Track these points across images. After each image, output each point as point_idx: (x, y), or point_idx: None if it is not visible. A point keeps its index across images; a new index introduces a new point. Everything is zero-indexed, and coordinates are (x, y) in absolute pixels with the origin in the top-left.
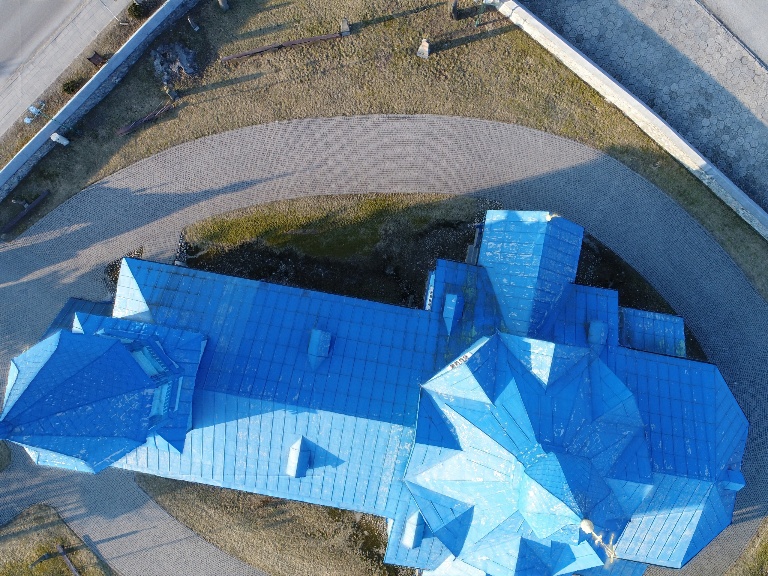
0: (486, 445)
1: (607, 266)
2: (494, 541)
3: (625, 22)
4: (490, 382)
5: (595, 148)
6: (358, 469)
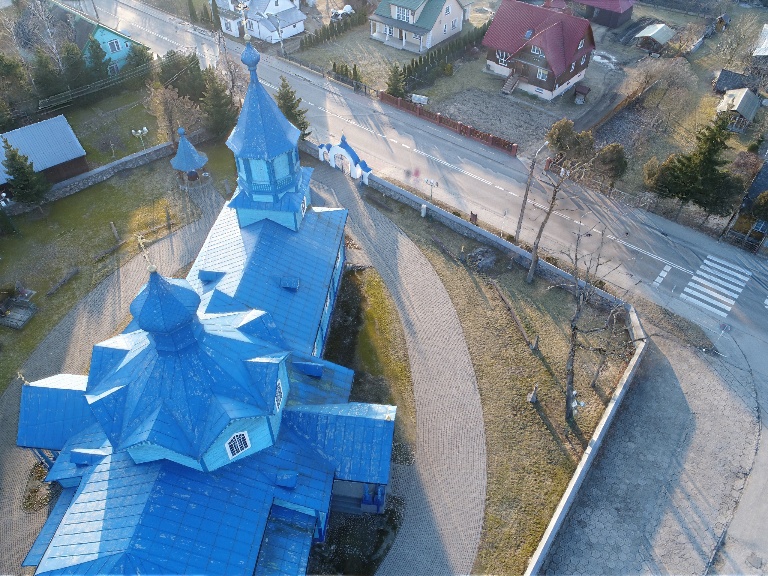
0: (207, 317)
1: (359, 569)
2: None
3: (614, 571)
4: (253, 331)
5: (479, 549)
6: None
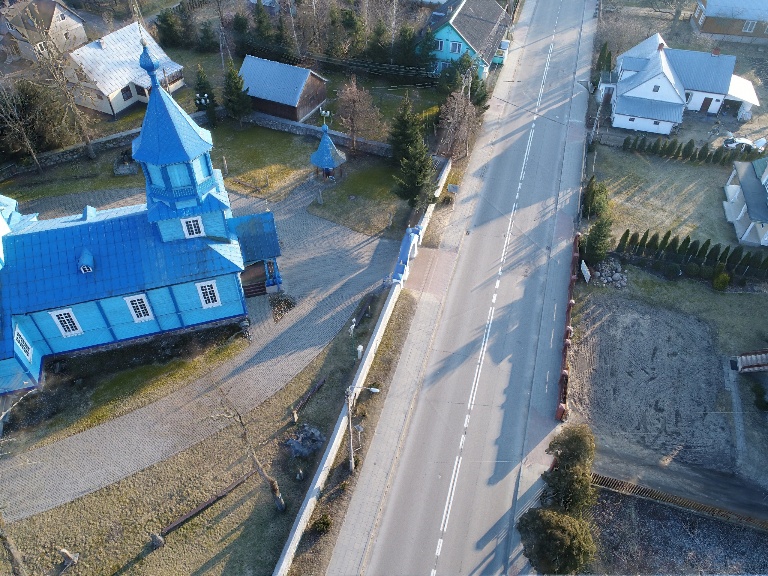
0: None
1: None
2: None
3: None
4: None
5: None
6: None
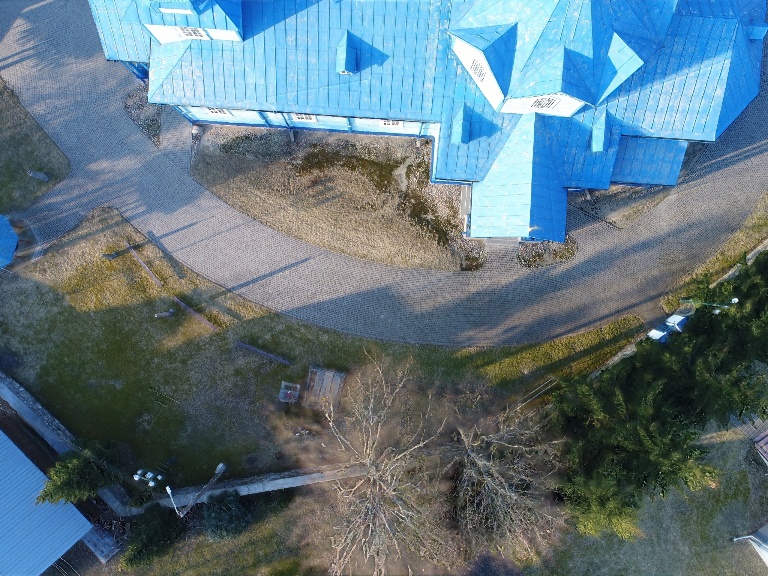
0: None
1: None
2: (539, 62)
3: None
4: None
5: None
6: (402, 64)
